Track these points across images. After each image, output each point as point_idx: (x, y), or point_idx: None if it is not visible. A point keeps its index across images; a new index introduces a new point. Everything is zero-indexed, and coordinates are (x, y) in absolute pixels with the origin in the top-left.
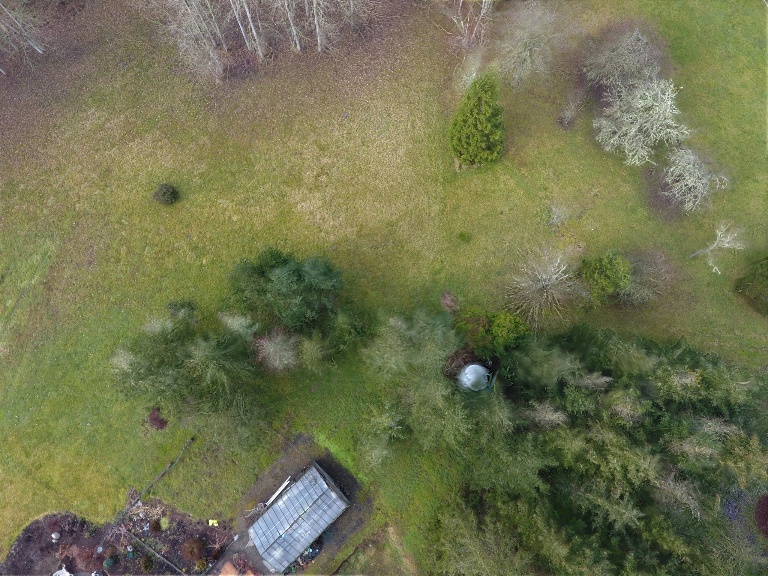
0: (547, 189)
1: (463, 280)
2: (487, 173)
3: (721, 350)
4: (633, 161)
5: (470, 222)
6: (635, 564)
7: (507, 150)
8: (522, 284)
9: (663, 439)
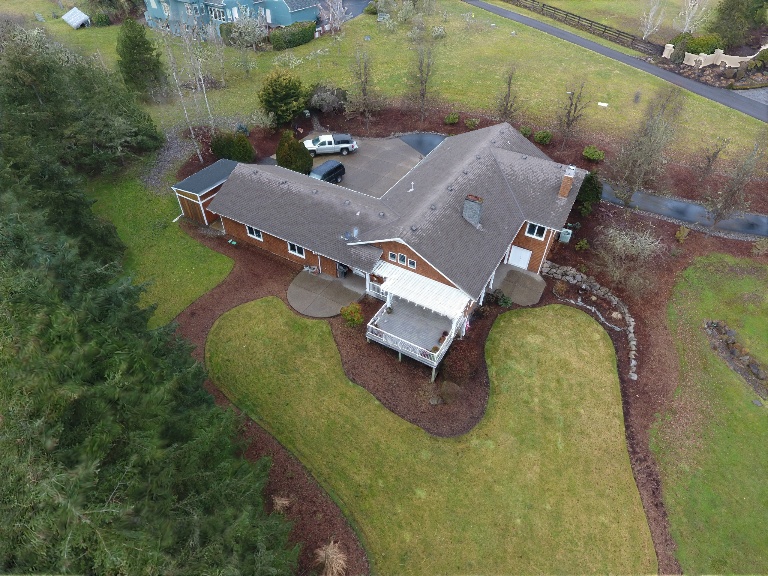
0: None
1: None
2: None
3: None
4: None
5: None
6: None
7: None
8: None
9: None
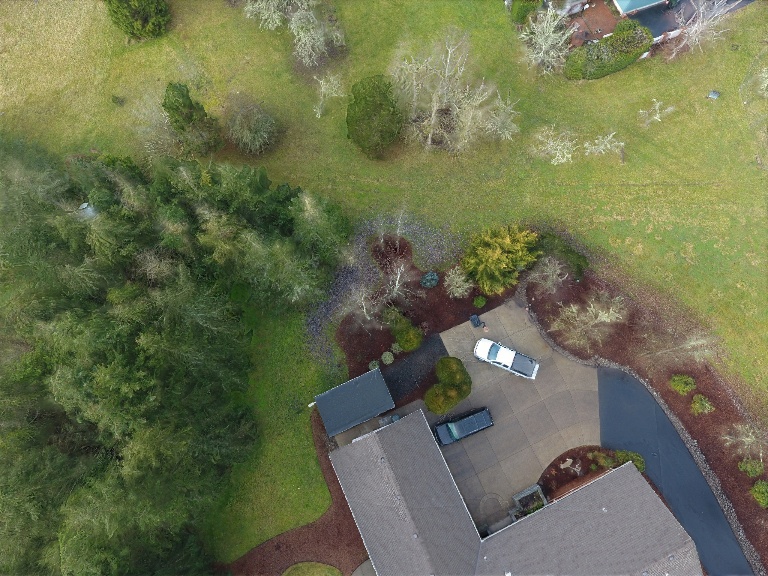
0: (204, 59)
1: (111, 138)
2: (152, 46)
3: (333, 193)
4: (267, 25)
5: (128, 88)
6: (82, 315)
7: (175, 26)
8: (162, 139)
9: (165, 228)
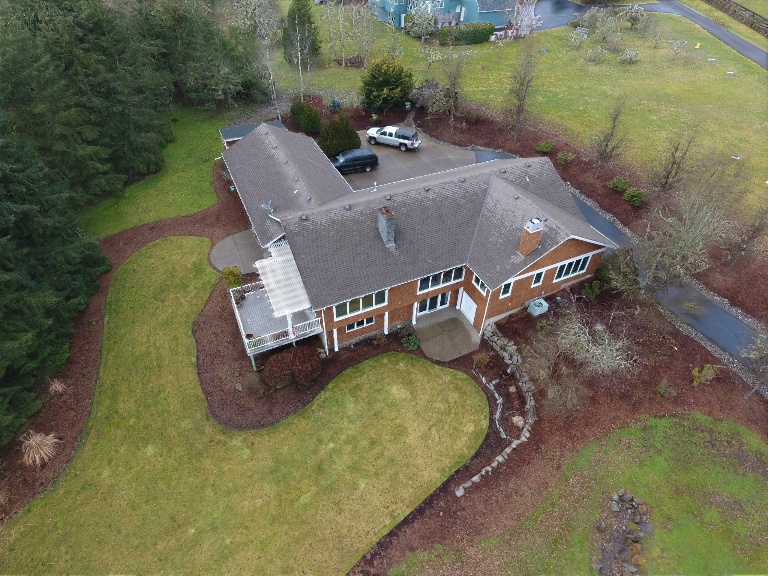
0: None
1: None
2: None
3: None
4: None
5: None
6: None
7: None
8: None
9: None
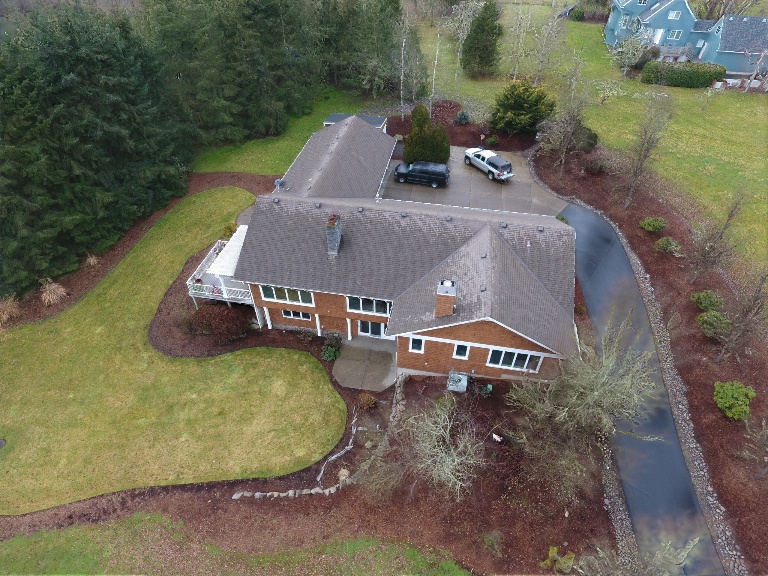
0: None
1: None
2: None
3: (431, 82)
4: None
5: None
6: None
7: None
8: None
9: None
